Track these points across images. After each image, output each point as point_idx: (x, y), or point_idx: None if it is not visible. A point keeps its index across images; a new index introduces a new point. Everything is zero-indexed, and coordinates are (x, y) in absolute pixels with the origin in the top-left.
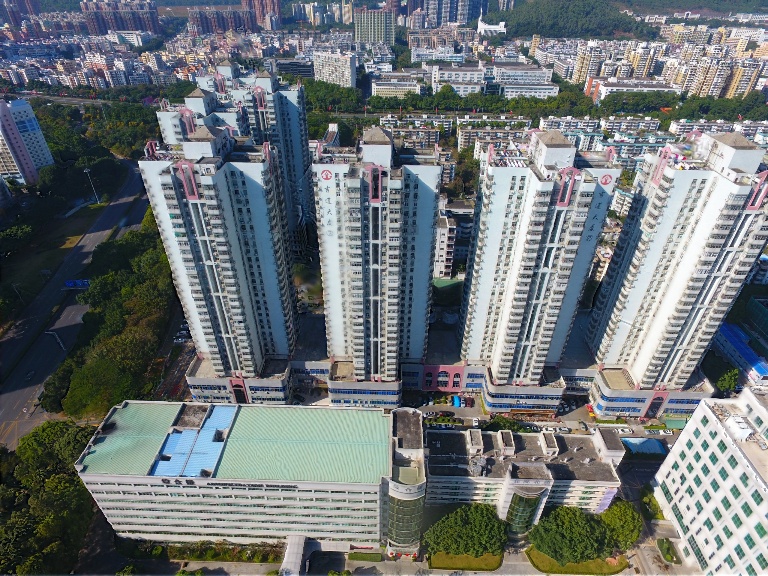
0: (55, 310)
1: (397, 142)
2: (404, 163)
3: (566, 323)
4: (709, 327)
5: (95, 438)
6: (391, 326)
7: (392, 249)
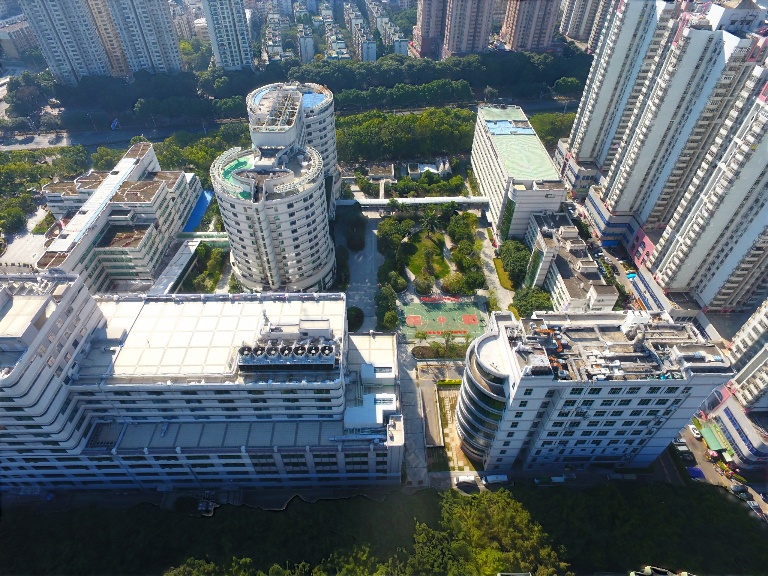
0: None
1: None
2: (737, 35)
3: (733, 263)
4: None
5: (496, 105)
6: (631, 160)
7: None
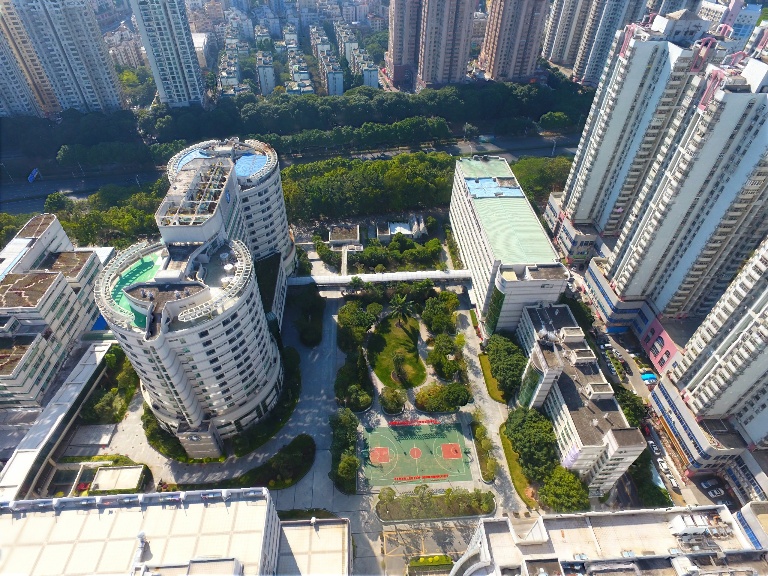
0: None
1: None
2: None
3: None
4: None
5: (477, 157)
6: (644, 240)
7: (684, 162)
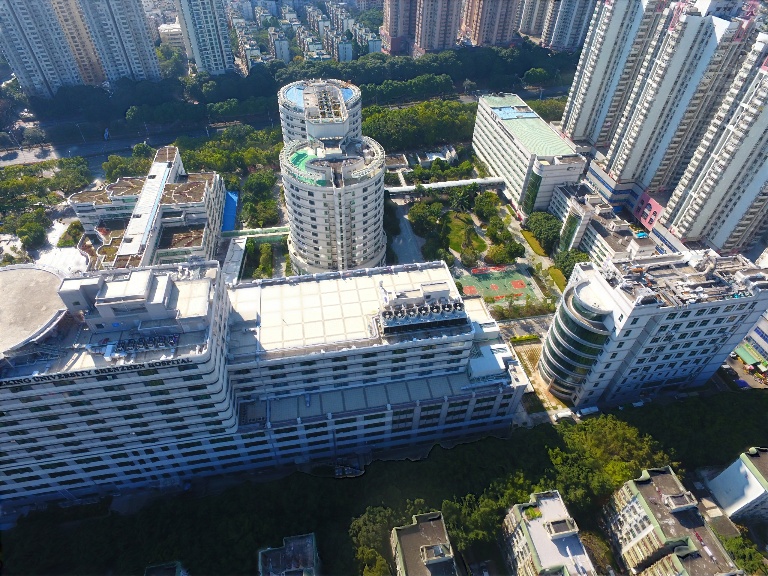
0: (559, 92)
1: (759, 16)
2: None
3: (742, 210)
4: None
5: (495, 94)
6: (634, 132)
7: (661, 69)
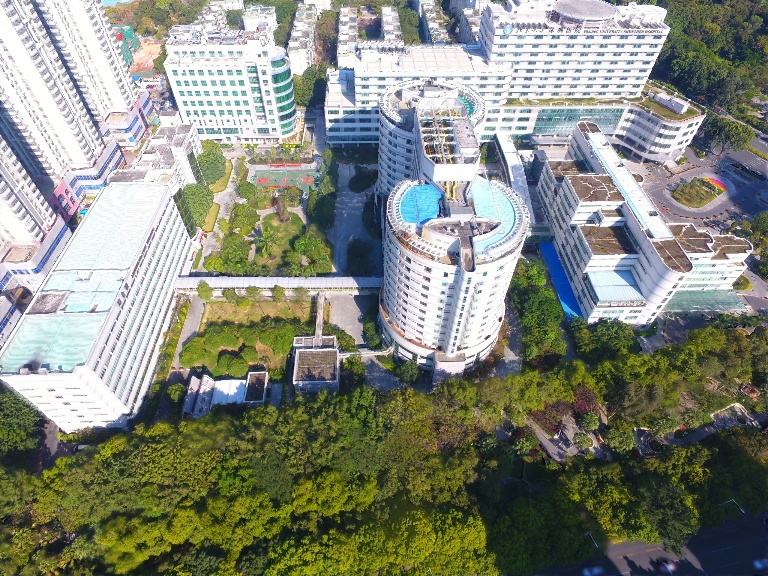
0: None
1: None
2: None
3: None
4: (115, 43)
5: None
6: (16, 164)
7: None
